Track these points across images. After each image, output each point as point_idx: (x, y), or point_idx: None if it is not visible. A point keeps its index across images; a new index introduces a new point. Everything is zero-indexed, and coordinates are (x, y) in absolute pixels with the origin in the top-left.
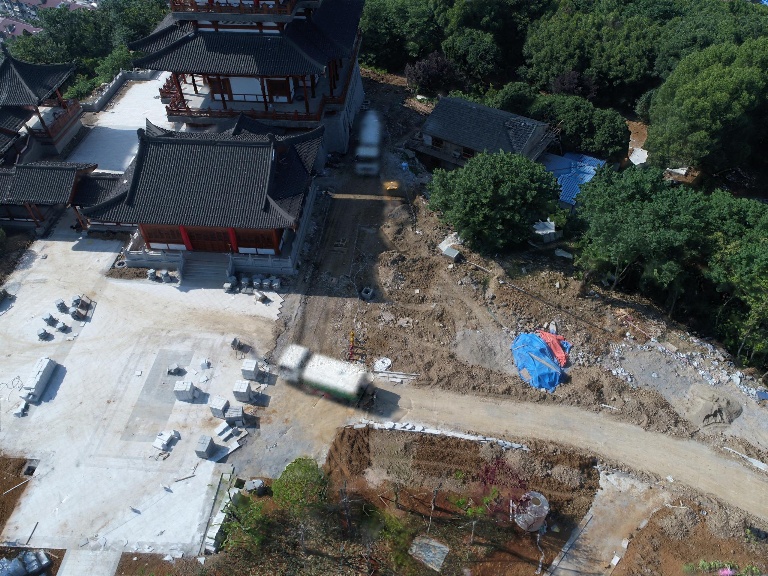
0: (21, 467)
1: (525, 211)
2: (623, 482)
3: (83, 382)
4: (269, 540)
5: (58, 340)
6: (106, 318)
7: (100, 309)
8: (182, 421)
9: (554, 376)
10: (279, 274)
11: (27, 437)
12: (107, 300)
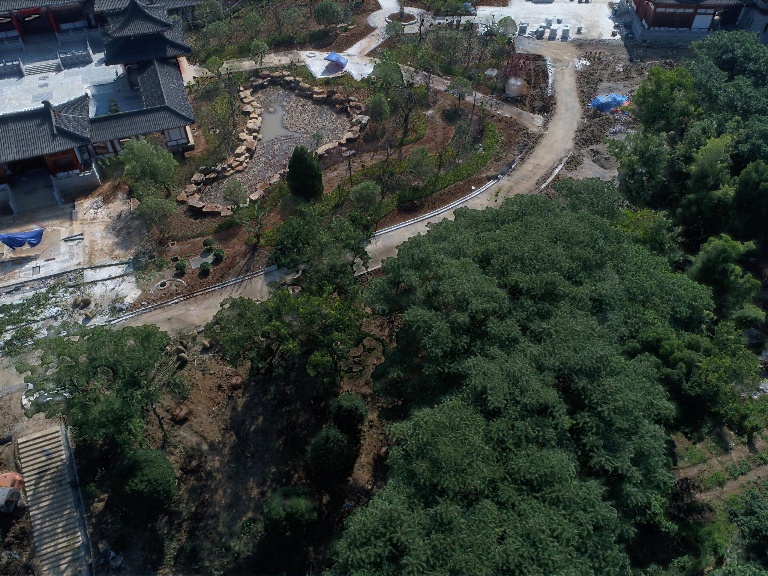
0: (505, 5)
1: (718, 65)
2: (539, 120)
3: (546, 7)
4: (488, 40)
5: (565, 0)
6: (582, 6)
7: (587, 4)
8: (534, 26)
9: (598, 103)
10: (635, 37)
11: (517, 3)
12: (593, 5)
